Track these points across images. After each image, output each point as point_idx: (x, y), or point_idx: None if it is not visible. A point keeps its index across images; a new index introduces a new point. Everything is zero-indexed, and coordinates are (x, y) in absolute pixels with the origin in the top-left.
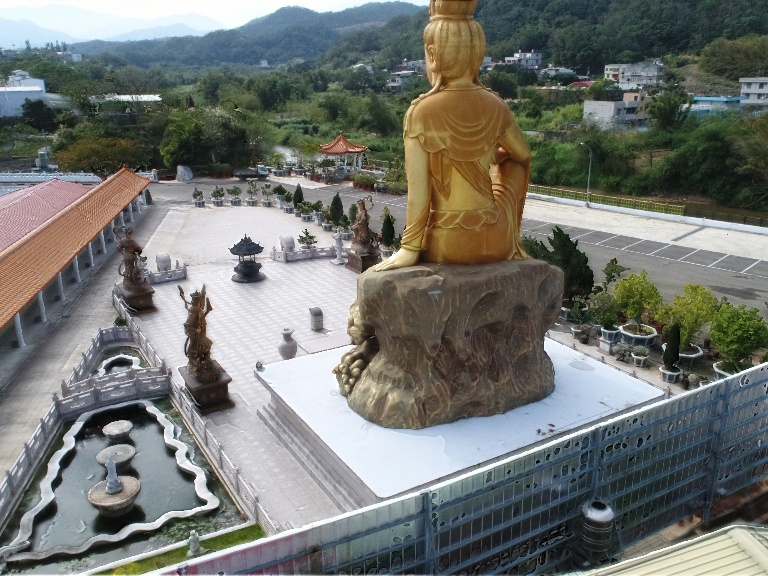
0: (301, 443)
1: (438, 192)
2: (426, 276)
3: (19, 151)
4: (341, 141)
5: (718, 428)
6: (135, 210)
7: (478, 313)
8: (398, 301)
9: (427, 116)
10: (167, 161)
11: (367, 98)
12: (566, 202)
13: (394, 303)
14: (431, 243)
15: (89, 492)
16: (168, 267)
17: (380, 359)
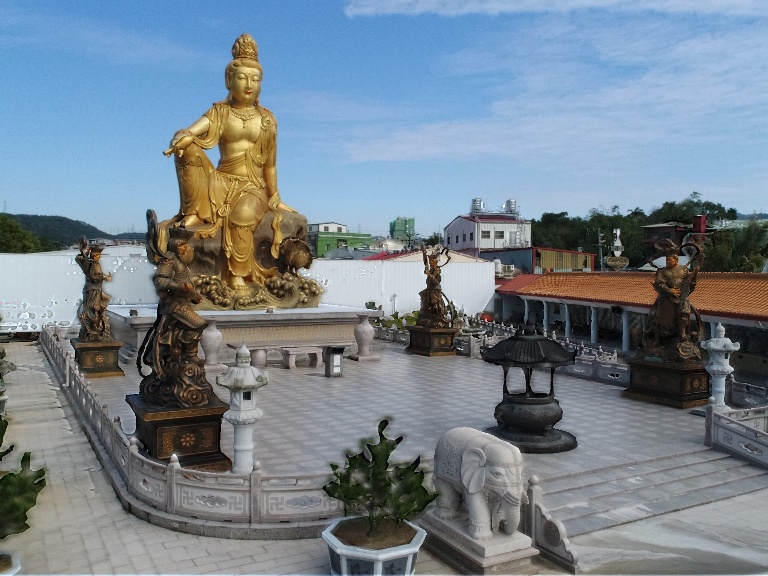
0: None
1: None
2: None
3: None
4: None
5: None
6: None
7: None
8: None
9: None
10: None
11: None
12: None
13: None
14: None
15: None
16: None
17: None
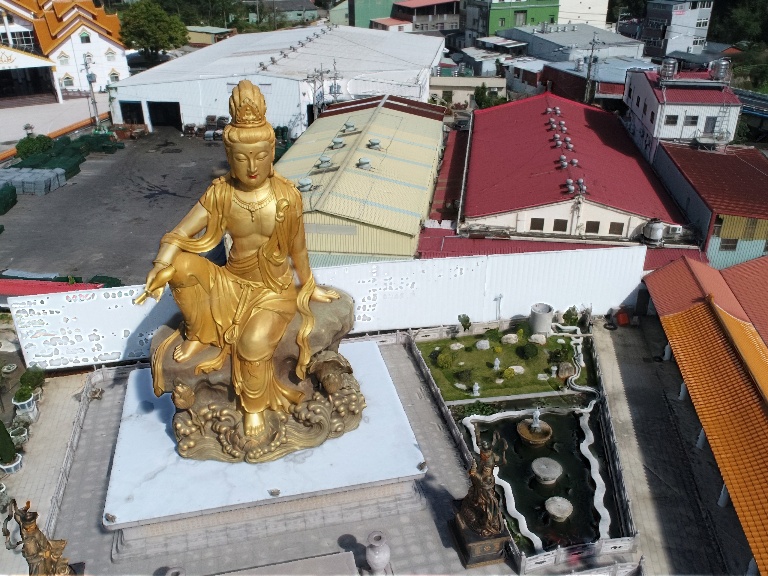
0: None
1: None
2: None
3: None
4: None
5: None
6: None
7: None
8: None
9: None
10: None
11: None
12: None
13: None
14: None
15: None
16: None
17: None
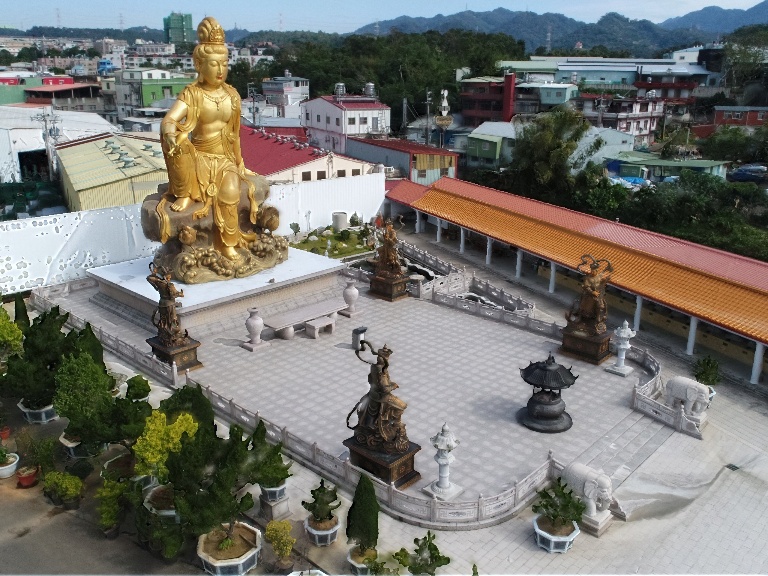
0: None
1: None
2: None
3: None
4: None
5: None
6: None
7: None
8: None
9: None
10: None
11: None
12: None
13: None
14: None
15: None
16: None
17: None
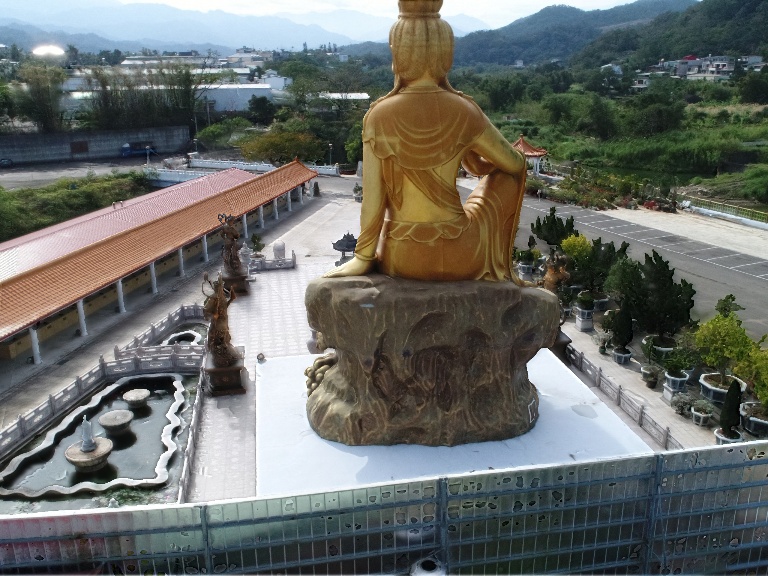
0: None
1: (392, 201)
2: (364, 288)
3: (239, 141)
4: (520, 144)
5: (650, 511)
6: (298, 200)
7: (422, 334)
8: (332, 310)
9: (378, 120)
10: (350, 156)
11: (589, 100)
12: (755, 225)
13: (330, 312)
14: (385, 254)
15: (70, 446)
16: (282, 255)
17: (335, 367)
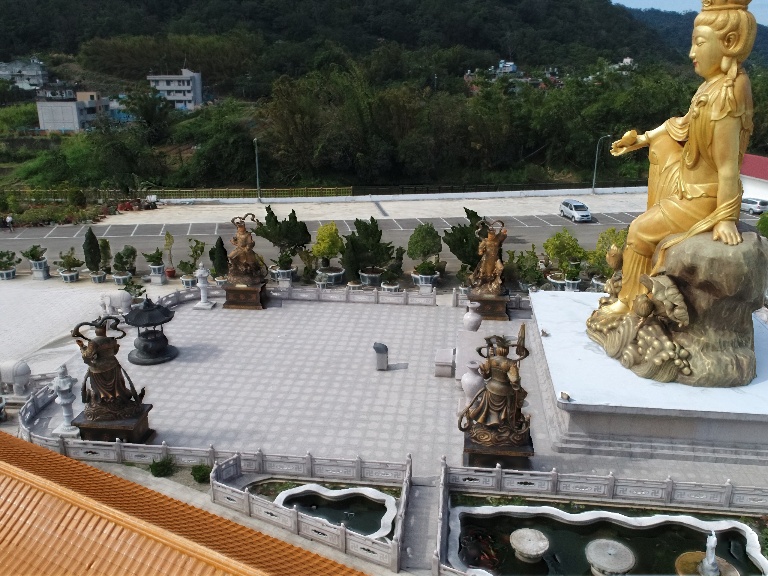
0: (669, 444)
1: None
2: None
3: None
4: None
5: None
6: None
7: None
8: (765, 265)
9: (746, 96)
10: None
11: None
12: (234, 202)
13: (760, 268)
14: None
15: None
16: (28, 381)
17: (708, 331)
